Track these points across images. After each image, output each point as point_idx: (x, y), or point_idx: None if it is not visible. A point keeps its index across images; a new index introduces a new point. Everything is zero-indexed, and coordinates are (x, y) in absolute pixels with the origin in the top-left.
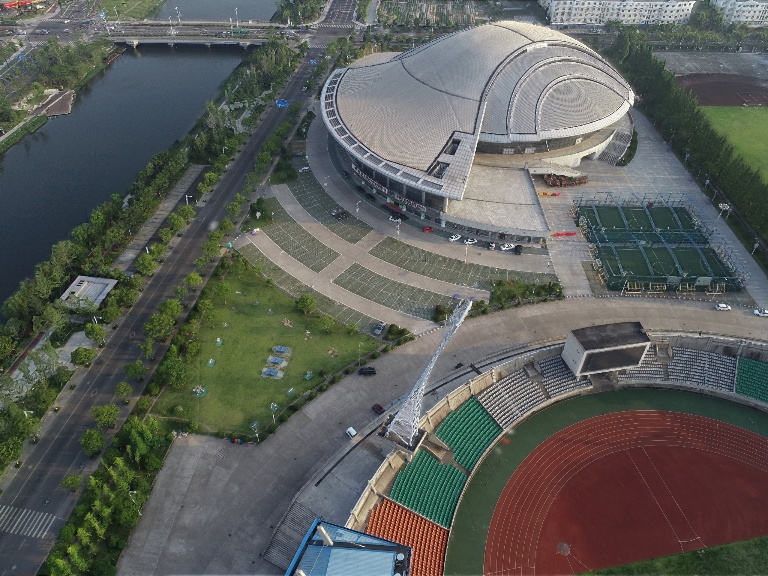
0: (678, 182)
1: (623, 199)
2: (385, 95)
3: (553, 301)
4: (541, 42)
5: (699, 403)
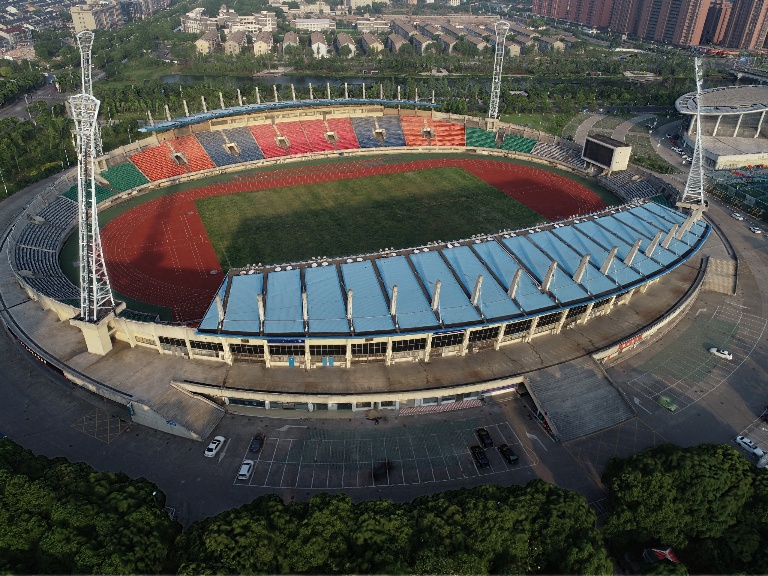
0: None
1: None
2: None
3: (655, 172)
4: None
5: (615, 202)
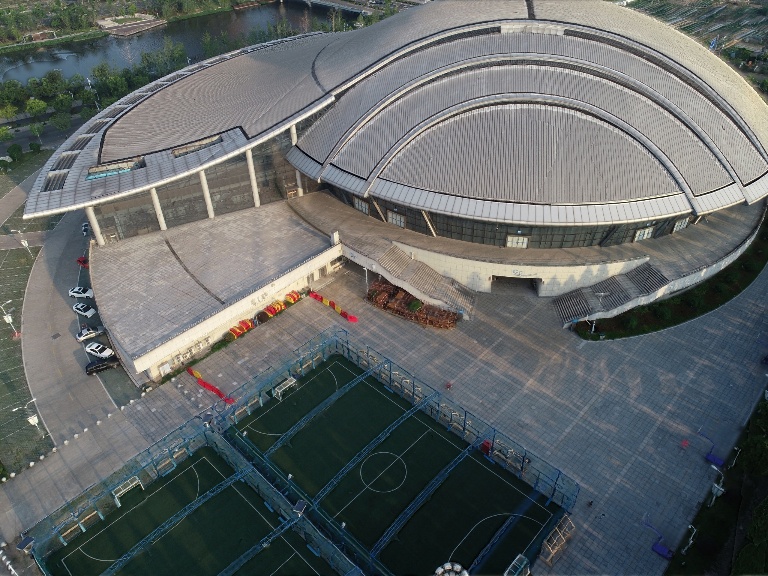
0: (665, 444)
1: (424, 395)
2: (272, 61)
3: None
4: (547, 22)
5: None
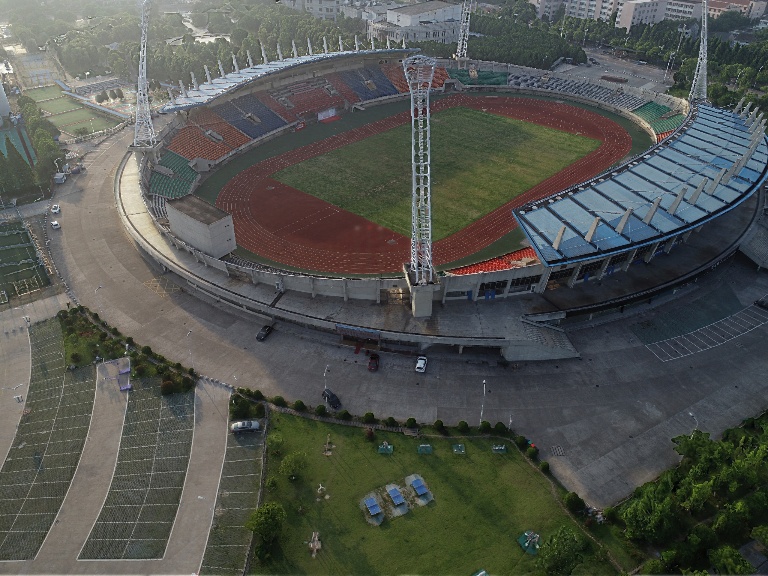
0: None
1: None
2: None
3: None
4: None
5: None
